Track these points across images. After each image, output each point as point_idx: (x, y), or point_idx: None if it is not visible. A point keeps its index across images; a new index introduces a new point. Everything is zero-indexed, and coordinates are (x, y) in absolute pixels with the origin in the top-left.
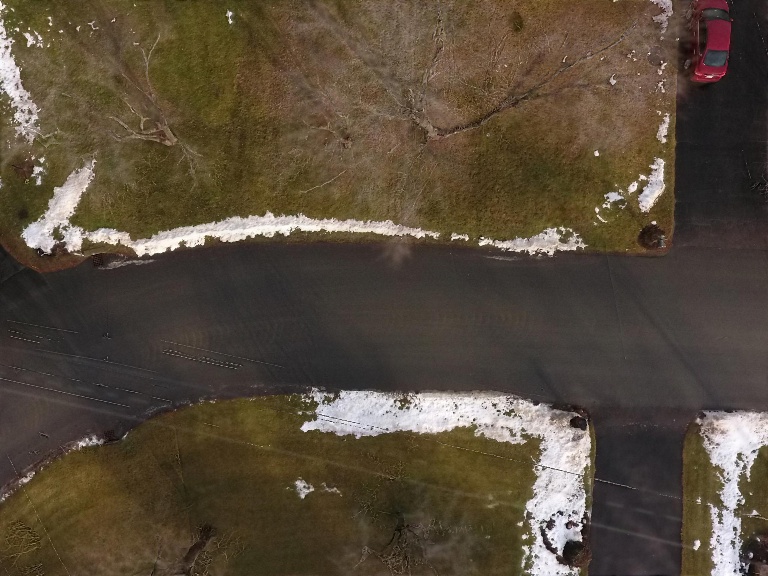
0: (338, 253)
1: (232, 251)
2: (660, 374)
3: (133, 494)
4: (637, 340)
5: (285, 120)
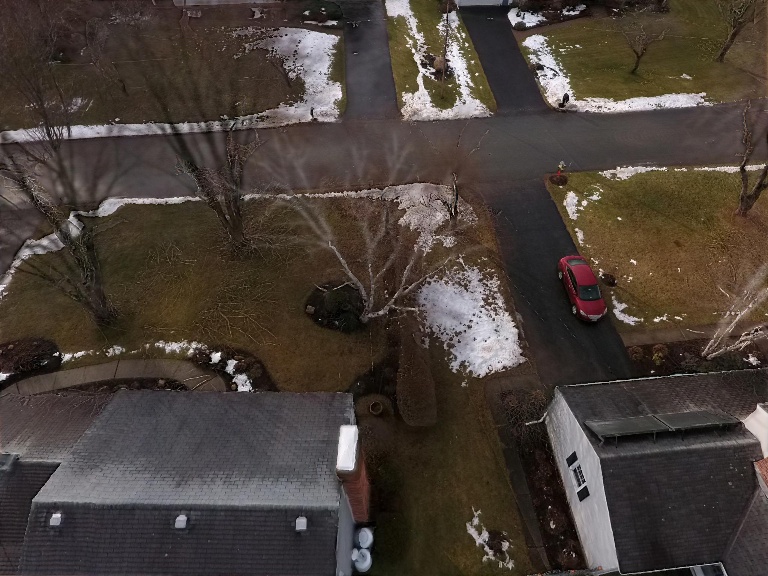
0: None
1: None
2: (523, 127)
3: (767, 68)
4: (544, 138)
5: None
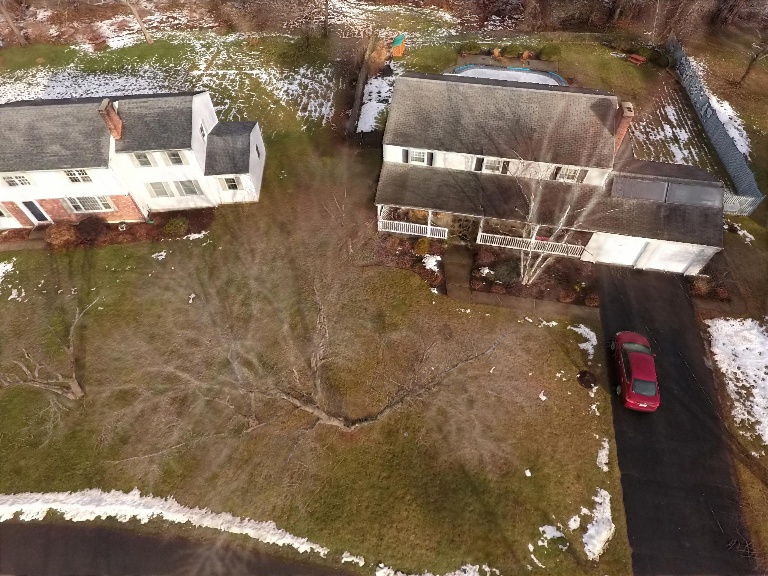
0: (196, 558)
1: (70, 534)
2: None
3: None
4: None
5: (200, 390)
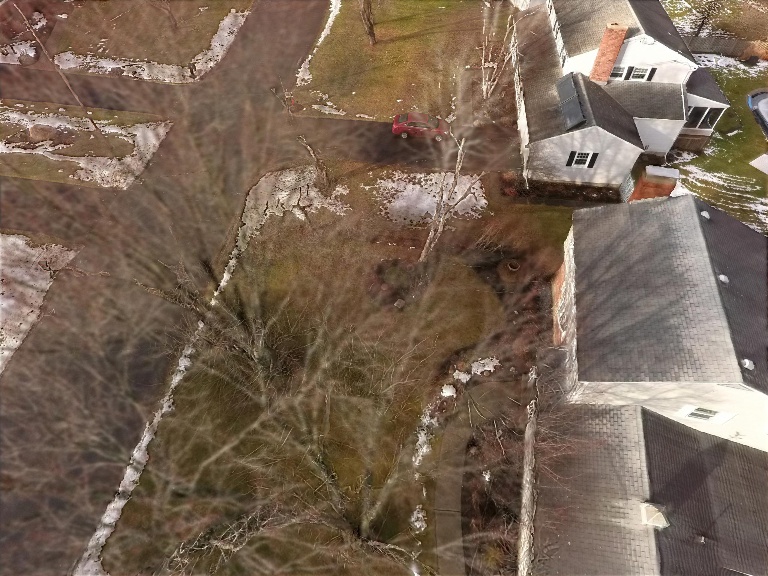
0: None
1: None
2: None
3: None
4: (232, 100)
5: None
